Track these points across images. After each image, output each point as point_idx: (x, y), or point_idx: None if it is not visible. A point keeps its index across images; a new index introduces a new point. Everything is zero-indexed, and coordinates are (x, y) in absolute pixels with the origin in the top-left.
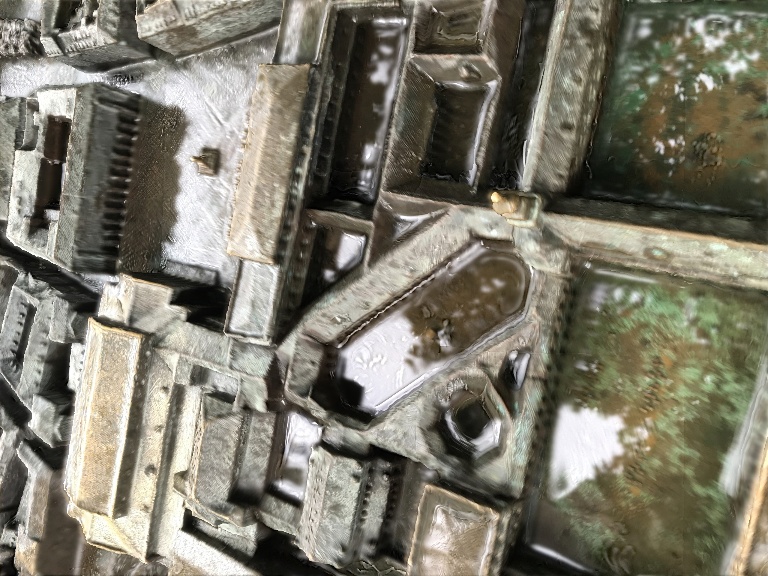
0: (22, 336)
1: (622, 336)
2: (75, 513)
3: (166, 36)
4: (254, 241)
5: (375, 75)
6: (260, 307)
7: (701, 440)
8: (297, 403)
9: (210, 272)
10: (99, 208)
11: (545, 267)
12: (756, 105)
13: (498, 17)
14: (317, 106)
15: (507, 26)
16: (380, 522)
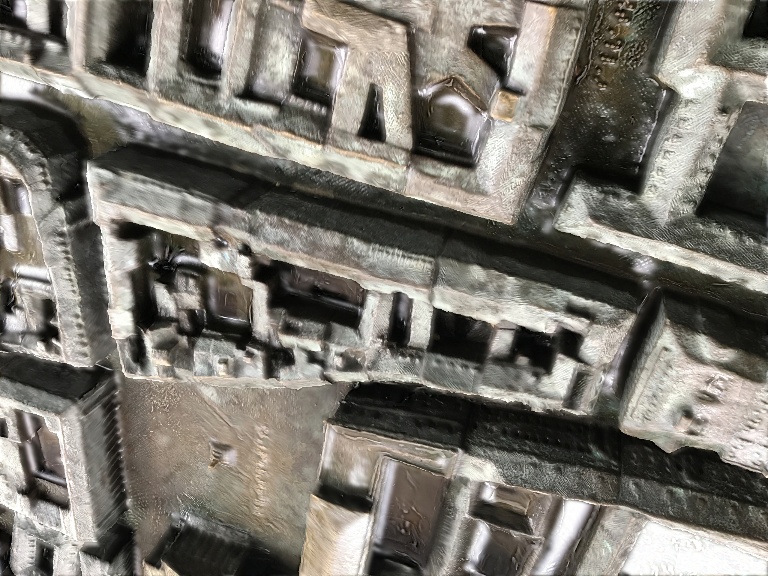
0: (36, 552)
1: None
2: None
3: None
4: None
5: None
6: None
7: None
8: None
9: (242, 534)
10: (104, 483)
11: None
12: (728, 569)
13: (548, 513)
14: None
15: (553, 511)
16: None
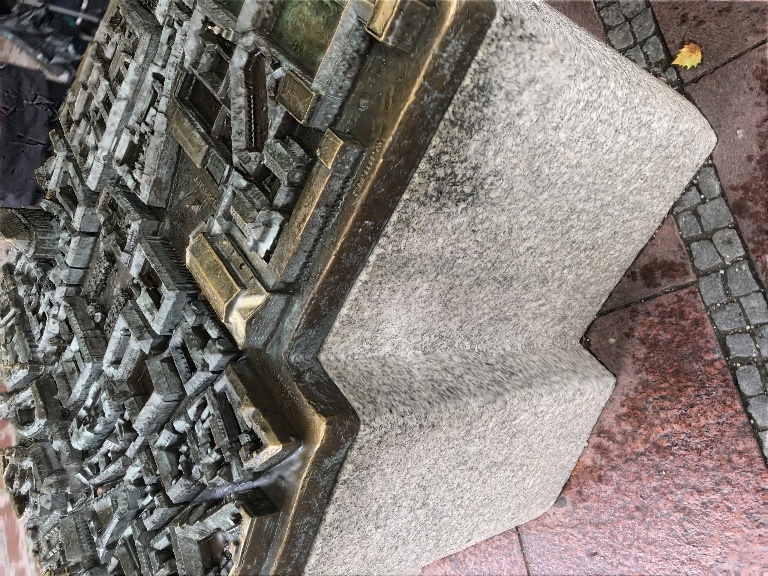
0: (188, 363)
1: (292, 31)
2: (240, 339)
3: (153, 193)
4: (199, 149)
5: (207, 105)
6: (219, 165)
7: (320, 10)
8: (254, 169)
9: None
10: (175, 270)
11: (252, 39)
12: None
13: (204, 38)
14: (190, 114)
15: None
16: (302, 150)
